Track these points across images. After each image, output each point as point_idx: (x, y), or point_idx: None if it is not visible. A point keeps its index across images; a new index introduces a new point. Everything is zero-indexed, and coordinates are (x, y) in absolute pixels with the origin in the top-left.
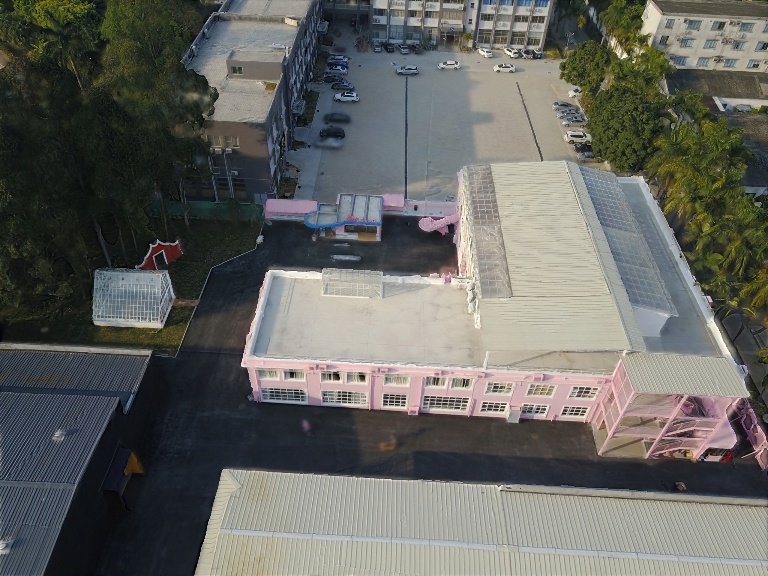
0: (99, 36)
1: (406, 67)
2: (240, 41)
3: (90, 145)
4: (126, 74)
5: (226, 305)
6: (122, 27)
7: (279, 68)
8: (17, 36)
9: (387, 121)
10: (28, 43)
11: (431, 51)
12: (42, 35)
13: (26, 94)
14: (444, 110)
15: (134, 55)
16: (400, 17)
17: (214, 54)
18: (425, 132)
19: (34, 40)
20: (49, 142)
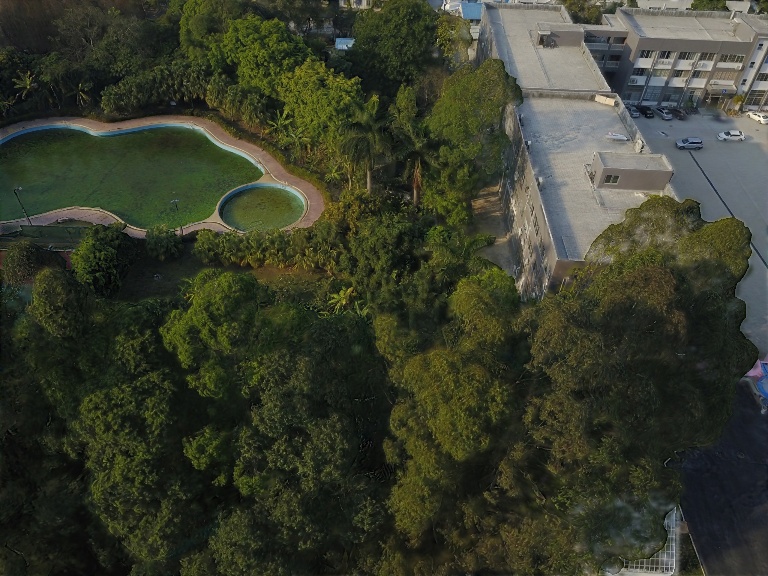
0: (426, 134)
1: (689, 140)
2: (563, 129)
3: (716, 382)
4: (733, 266)
5: (726, 531)
6: (470, 126)
7: (667, 177)
8: (254, 112)
9: (712, 216)
10: (265, 120)
11: (693, 115)
12: (351, 131)
13: (683, 329)
14: (767, 199)
15: (742, 238)
16: (662, 77)
17: (548, 149)
18: (767, 232)
19: (271, 116)
20: (689, 390)
